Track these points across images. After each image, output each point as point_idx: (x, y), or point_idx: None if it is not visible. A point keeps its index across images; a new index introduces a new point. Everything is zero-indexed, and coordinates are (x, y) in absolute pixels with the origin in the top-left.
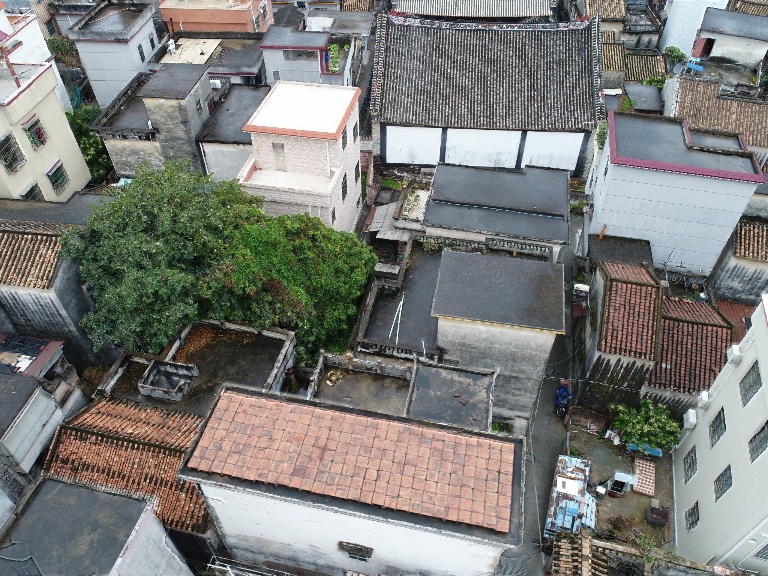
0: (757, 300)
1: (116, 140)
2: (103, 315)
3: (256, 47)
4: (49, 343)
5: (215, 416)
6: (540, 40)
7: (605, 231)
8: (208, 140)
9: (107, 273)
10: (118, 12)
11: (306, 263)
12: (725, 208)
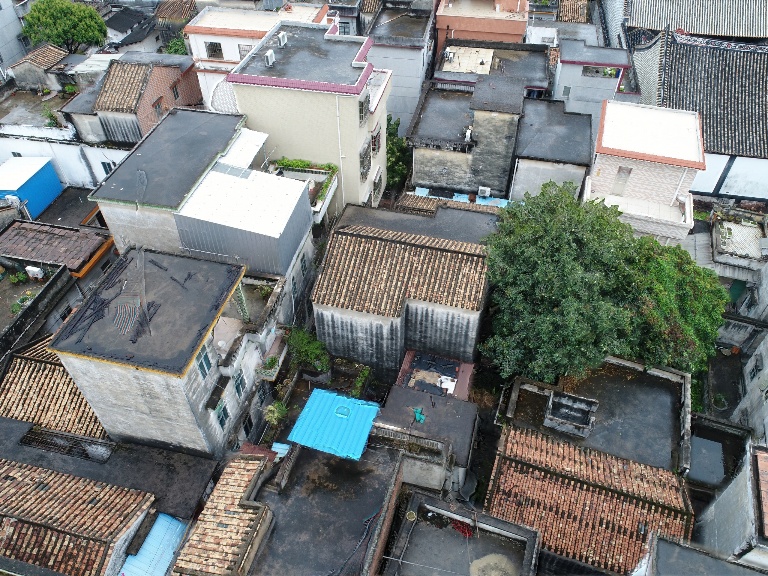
0: None
1: (427, 150)
2: (515, 341)
3: (533, 59)
4: (461, 364)
5: (764, 479)
6: None
7: None
8: (528, 157)
9: (524, 298)
10: (398, 17)
11: (684, 299)
12: None
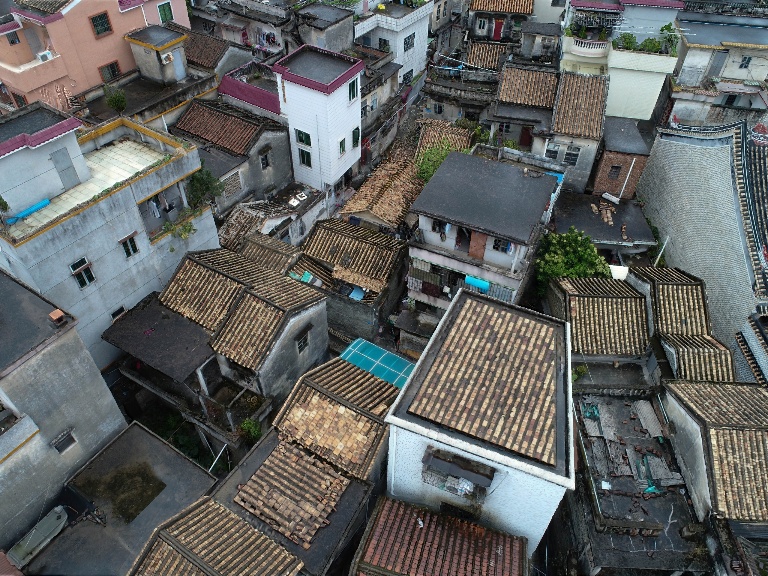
0: None
1: None
2: None
3: None
4: None
5: None
6: None
7: None
8: None
9: None
10: None
11: None
12: None
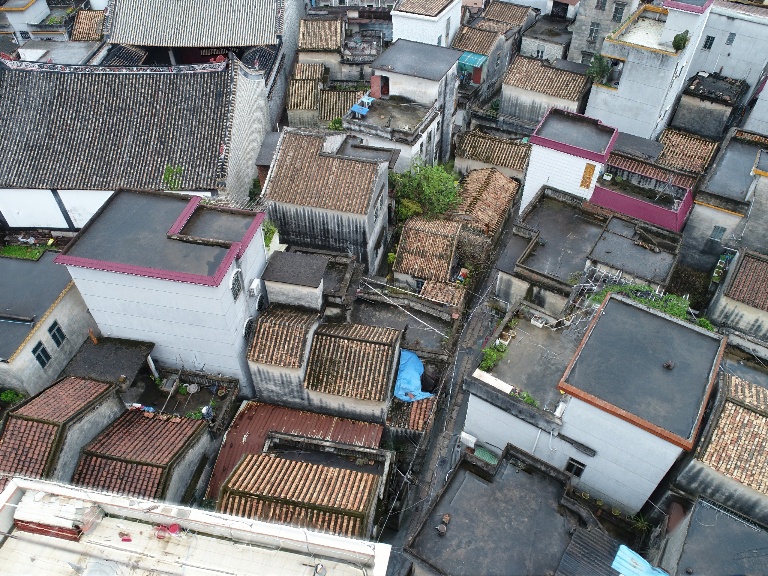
0: (305, 403)
1: None
2: None
3: None
4: None
5: None
6: (175, 84)
7: (111, 331)
8: None
9: None
10: None
11: None
12: (204, 310)
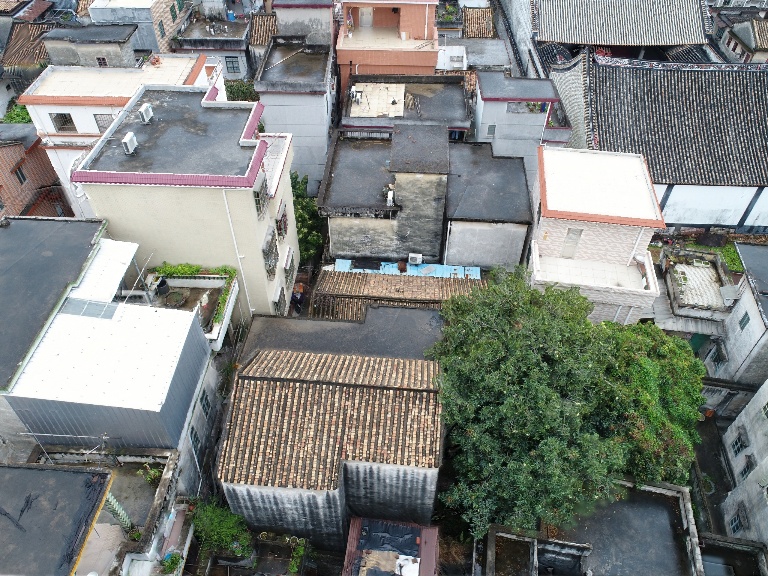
0: None
1: (344, 218)
2: (485, 490)
3: (449, 93)
4: (422, 531)
5: None
6: (763, 82)
7: None
8: (461, 218)
9: (490, 435)
10: (292, 55)
11: (664, 389)
12: None
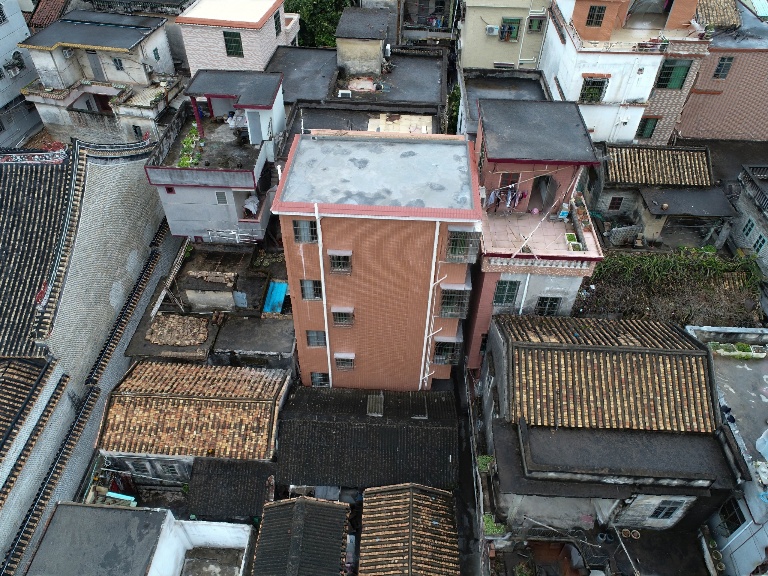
0: None
1: None
2: None
3: None
4: None
5: None
6: None
7: None
8: (333, 49)
9: None
10: None
11: None
12: None
